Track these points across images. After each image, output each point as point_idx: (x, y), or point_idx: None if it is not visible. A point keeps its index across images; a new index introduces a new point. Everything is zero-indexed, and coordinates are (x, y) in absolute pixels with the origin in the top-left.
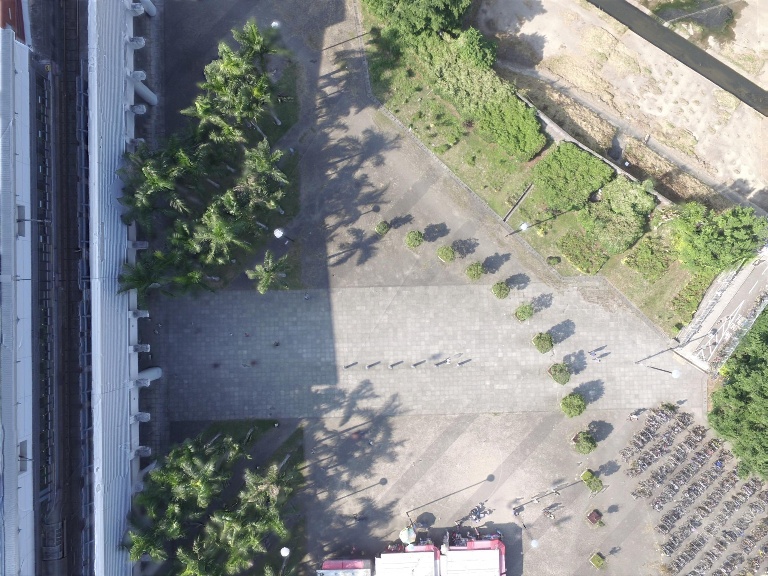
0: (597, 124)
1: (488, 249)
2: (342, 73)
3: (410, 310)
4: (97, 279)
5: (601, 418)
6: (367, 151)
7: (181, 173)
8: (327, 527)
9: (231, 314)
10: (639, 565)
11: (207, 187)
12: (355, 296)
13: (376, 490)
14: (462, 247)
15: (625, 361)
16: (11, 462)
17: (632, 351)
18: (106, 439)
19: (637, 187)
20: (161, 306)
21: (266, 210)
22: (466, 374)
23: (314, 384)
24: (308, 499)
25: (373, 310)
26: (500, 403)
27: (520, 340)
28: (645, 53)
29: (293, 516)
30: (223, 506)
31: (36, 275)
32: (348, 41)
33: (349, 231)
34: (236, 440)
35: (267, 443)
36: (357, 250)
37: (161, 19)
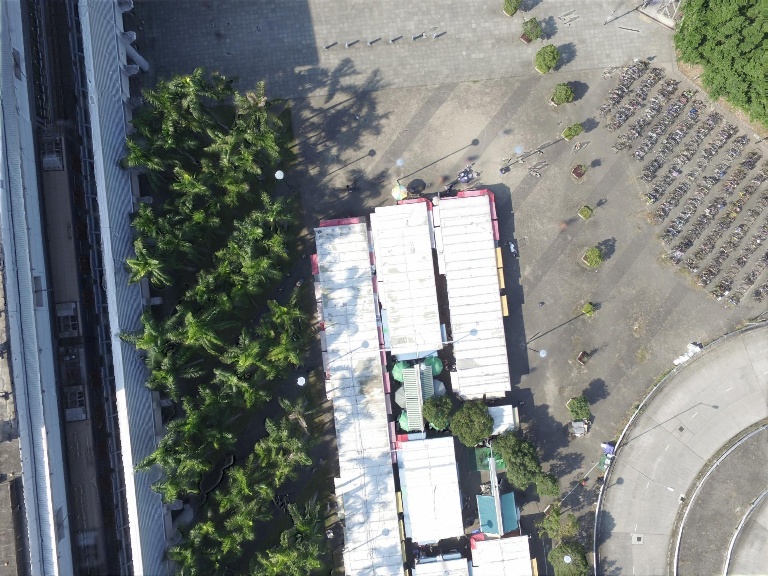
0: None
1: None
2: None
3: None
4: None
5: (576, 79)
6: None
7: None
8: (321, 201)
9: (211, 6)
10: (626, 215)
11: None
12: None
13: (366, 161)
14: None
15: (594, 24)
16: (5, 44)
17: (600, 14)
18: (96, 54)
19: None
20: (143, 3)
21: None
22: (443, 46)
23: (297, 66)
24: (301, 176)
25: None
26: (478, 71)
27: (491, 11)
28: None
29: (288, 193)
30: (216, 141)
31: None
32: None
33: None
34: None
35: None
36: None
37: None
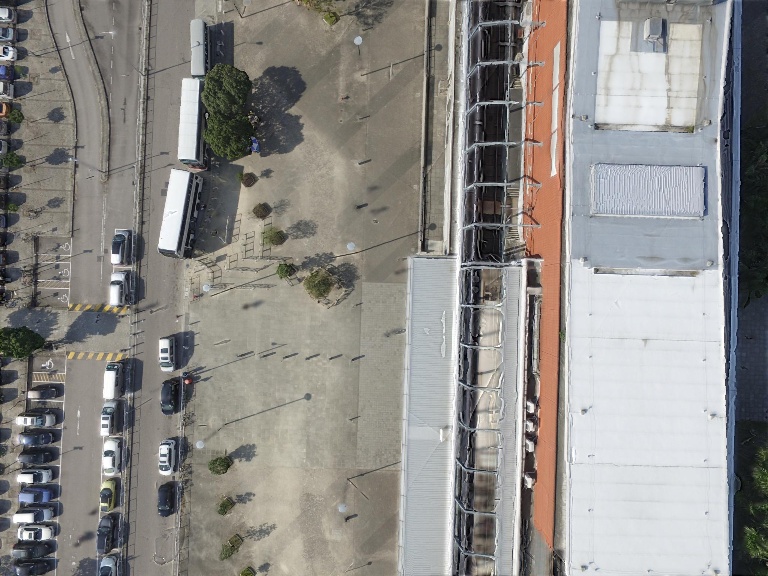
0: None
1: None
2: None
3: None
4: (736, 277)
5: None
6: None
7: None
8: None
9: None
10: None
11: None
12: None
13: None
14: None
15: None
16: None
17: None
18: None
19: None
20: None
21: None
22: None
23: None
24: None
25: None
26: None
27: None
28: None
29: None
30: None
31: None
32: None
33: None
34: None
35: None
36: None
37: None
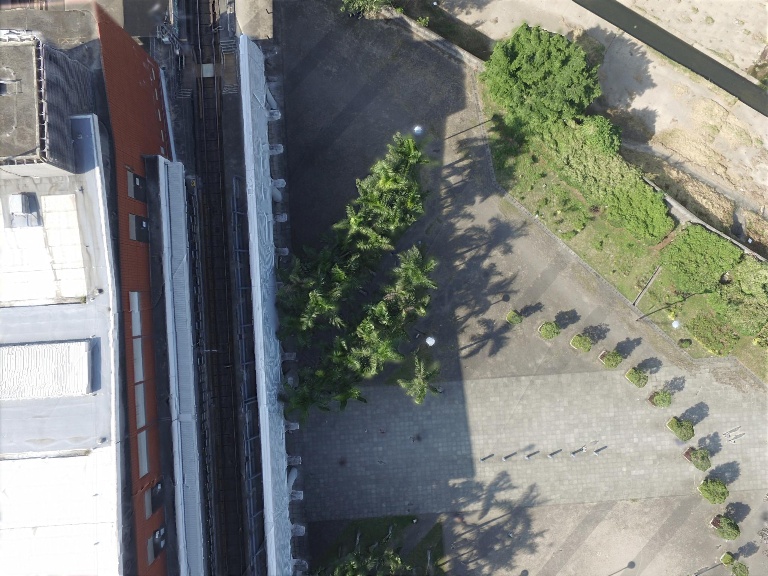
0: (716, 200)
1: (619, 334)
2: (466, 162)
3: (544, 399)
4: (265, 405)
5: (738, 500)
6: (494, 240)
7: (341, 291)
8: None
9: (365, 411)
10: None
11: (357, 297)
12: (488, 387)
13: None
14: (593, 333)
15: (759, 441)
16: None
17: (766, 431)
18: (278, 566)
19: (767, 268)
20: None
21: (414, 316)
22: (602, 461)
23: (451, 478)
24: None
25: (507, 401)
26: (637, 489)
27: (655, 425)
28: (756, 124)
29: None
30: None
31: (198, 400)
32: (470, 129)
33: (480, 322)
34: (395, 551)
35: (406, 540)
36: (488, 340)
37: (282, 114)
